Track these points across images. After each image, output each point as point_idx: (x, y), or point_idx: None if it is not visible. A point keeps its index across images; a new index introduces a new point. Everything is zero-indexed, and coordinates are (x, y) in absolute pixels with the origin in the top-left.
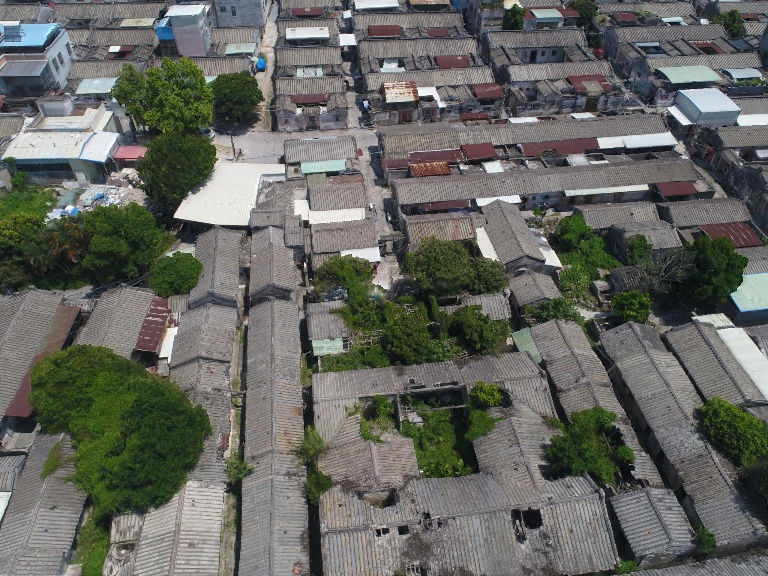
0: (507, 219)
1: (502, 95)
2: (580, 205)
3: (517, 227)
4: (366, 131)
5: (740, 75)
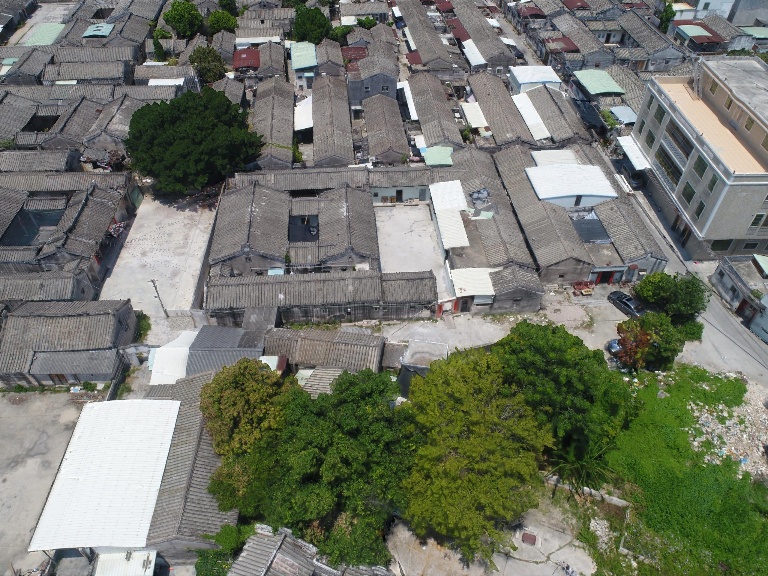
0: (368, 2)
1: (524, 15)
2: (394, 31)
3: (365, 7)
4: (489, 0)
5: (617, 111)
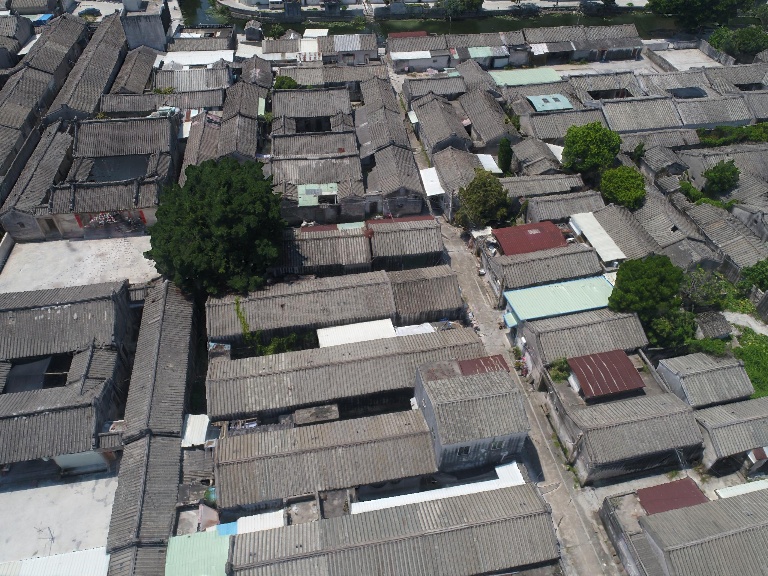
0: None
1: None
2: None
3: None
4: None
5: None
